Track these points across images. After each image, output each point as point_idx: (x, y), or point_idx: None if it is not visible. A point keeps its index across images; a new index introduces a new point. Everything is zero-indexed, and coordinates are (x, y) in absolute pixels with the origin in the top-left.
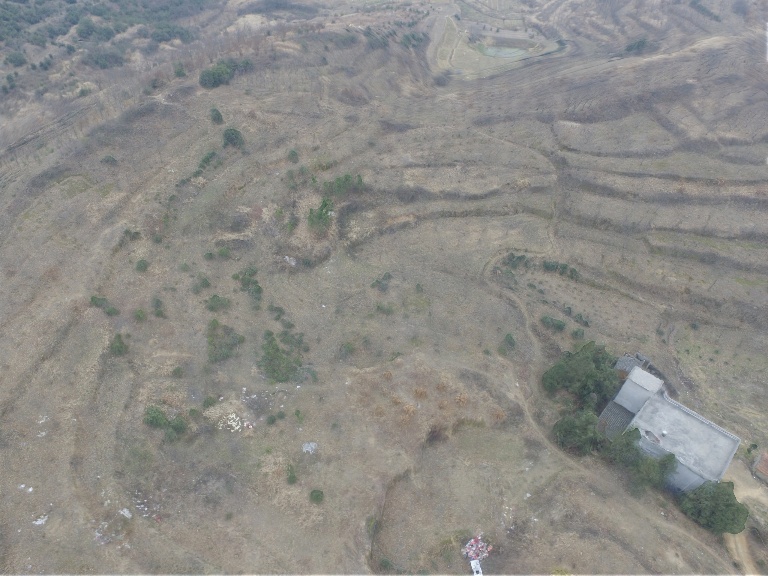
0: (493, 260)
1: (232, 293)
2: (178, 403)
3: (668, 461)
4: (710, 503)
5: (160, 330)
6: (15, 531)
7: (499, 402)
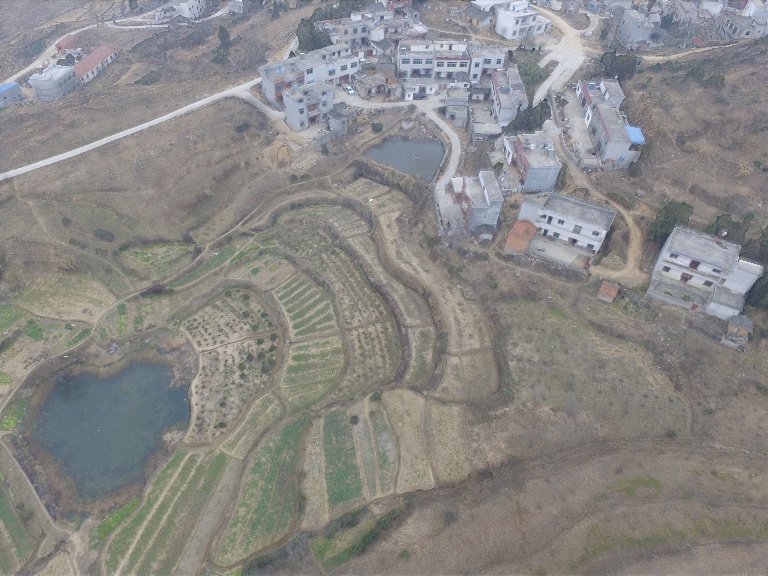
0: None
1: None
2: None
3: None
4: None
5: None
6: None
7: None
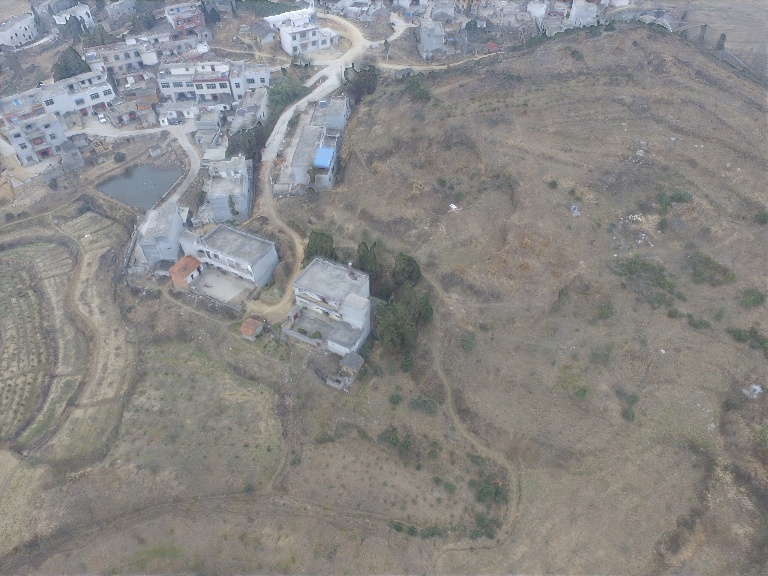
0: (513, 514)
1: (757, 320)
2: (681, 212)
3: None
4: None
5: (760, 248)
6: None
7: (463, 288)
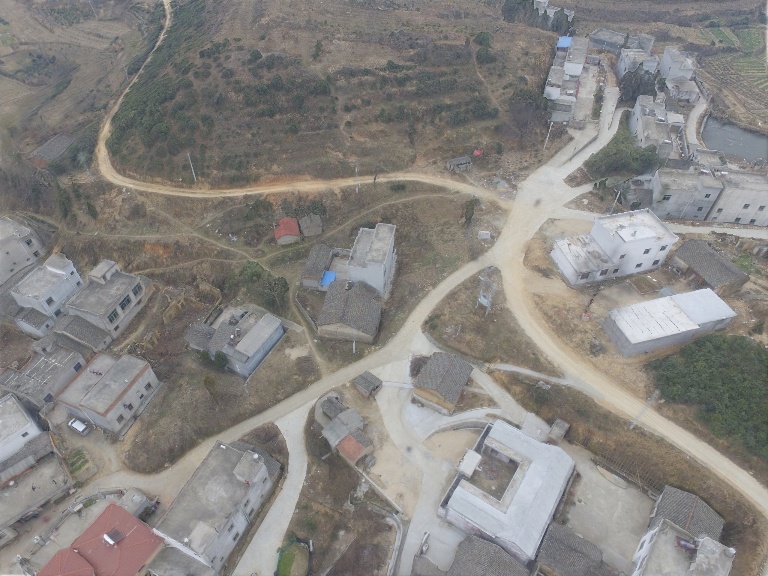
0: None
1: None
2: None
3: (545, 14)
4: (556, 16)
5: None
6: (322, 6)
7: None
